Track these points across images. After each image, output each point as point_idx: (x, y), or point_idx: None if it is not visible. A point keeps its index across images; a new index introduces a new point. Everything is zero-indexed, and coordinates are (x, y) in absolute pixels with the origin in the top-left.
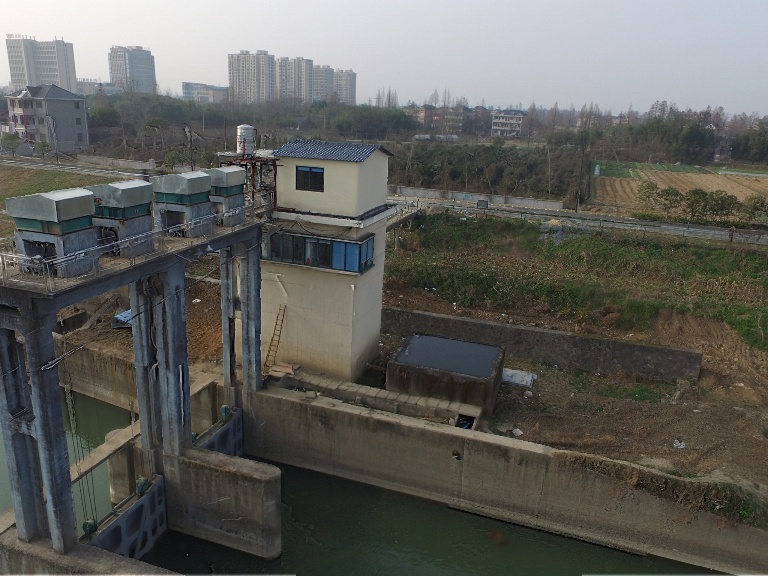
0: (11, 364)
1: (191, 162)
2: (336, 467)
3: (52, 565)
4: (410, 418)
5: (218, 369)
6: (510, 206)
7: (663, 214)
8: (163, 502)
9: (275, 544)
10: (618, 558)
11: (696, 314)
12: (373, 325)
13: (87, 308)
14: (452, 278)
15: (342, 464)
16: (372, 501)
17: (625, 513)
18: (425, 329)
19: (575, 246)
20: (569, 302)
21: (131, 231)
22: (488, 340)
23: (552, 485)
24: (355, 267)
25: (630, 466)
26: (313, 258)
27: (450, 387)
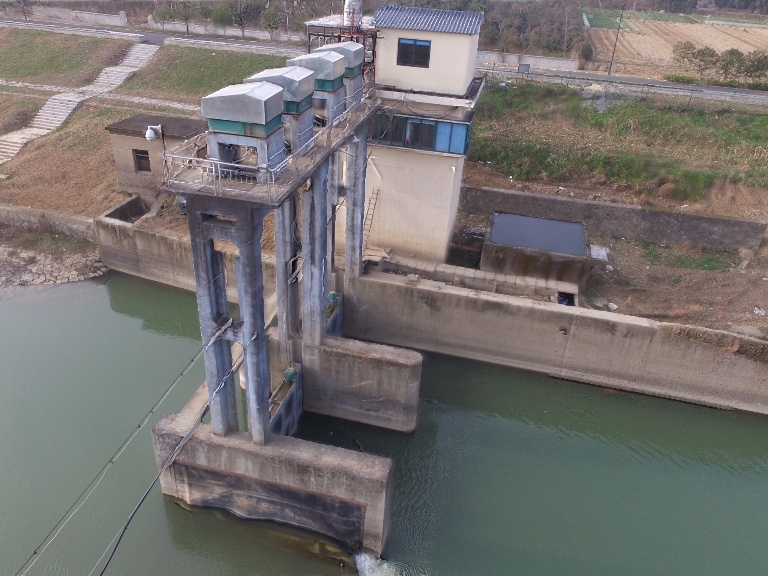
0: (212, 273)
1: (184, 18)
2: (439, 345)
3: (256, 456)
4: (516, 298)
5: None
6: (540, 68)
7: (696, 76)
8: (301, 387)
9: (414, 419)
10: (706, 413)
11: (748, 183)
12: (456, 205)
13: (141, 192)
14: (506, 150)
15: (445, 342)
16: (477, 374)
17: (720, 375)
18: (493, 205)
19: (620, 113)
20: (624, 173)
21: (302, 126)
22: (557, 215)
23: (654, 354)
24: (460, 149)
25: (731, 335)
26: (413, 139)
27: (547, 266)
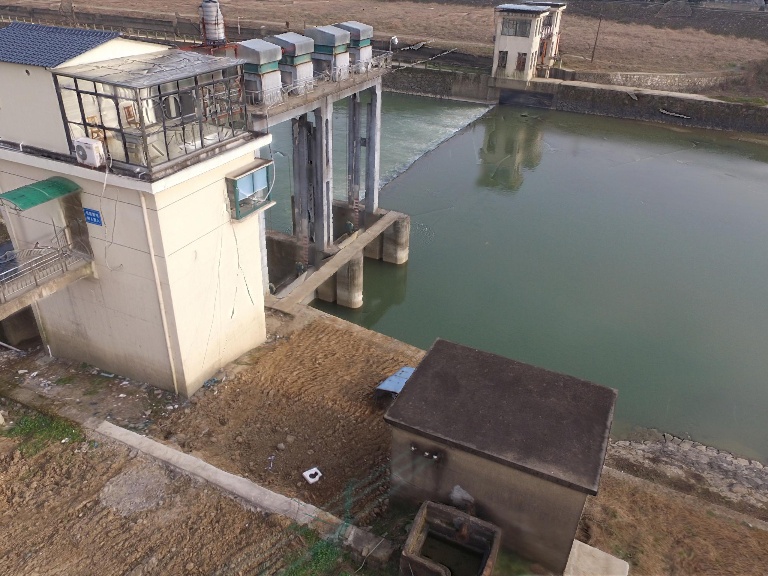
0: None
1: None
2: None
3: None
4: None
5: (276, 323)
6: None
7: None
8: None
9: None
10: None
11: None
12: None
13: None
14: None
15: None
16: None
17: None
18: None
19: None
20: None
21: None
22: None
23: None
24: None
25: None
26: None
27: None
